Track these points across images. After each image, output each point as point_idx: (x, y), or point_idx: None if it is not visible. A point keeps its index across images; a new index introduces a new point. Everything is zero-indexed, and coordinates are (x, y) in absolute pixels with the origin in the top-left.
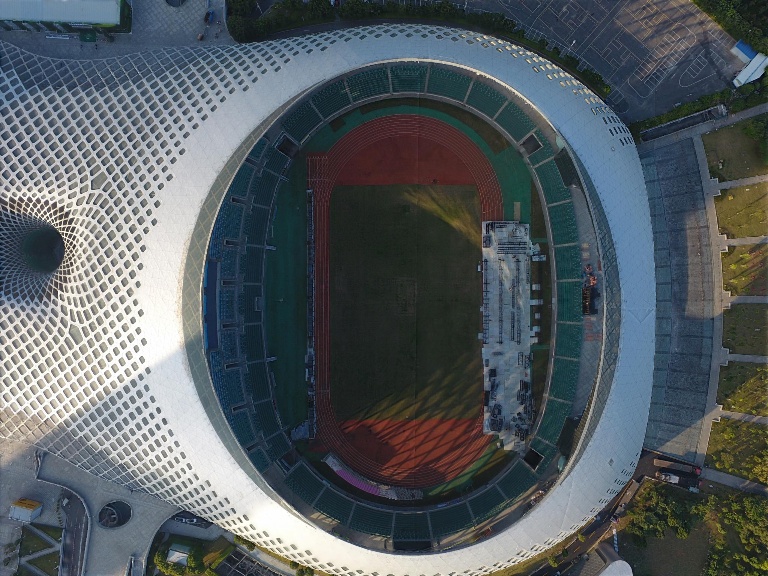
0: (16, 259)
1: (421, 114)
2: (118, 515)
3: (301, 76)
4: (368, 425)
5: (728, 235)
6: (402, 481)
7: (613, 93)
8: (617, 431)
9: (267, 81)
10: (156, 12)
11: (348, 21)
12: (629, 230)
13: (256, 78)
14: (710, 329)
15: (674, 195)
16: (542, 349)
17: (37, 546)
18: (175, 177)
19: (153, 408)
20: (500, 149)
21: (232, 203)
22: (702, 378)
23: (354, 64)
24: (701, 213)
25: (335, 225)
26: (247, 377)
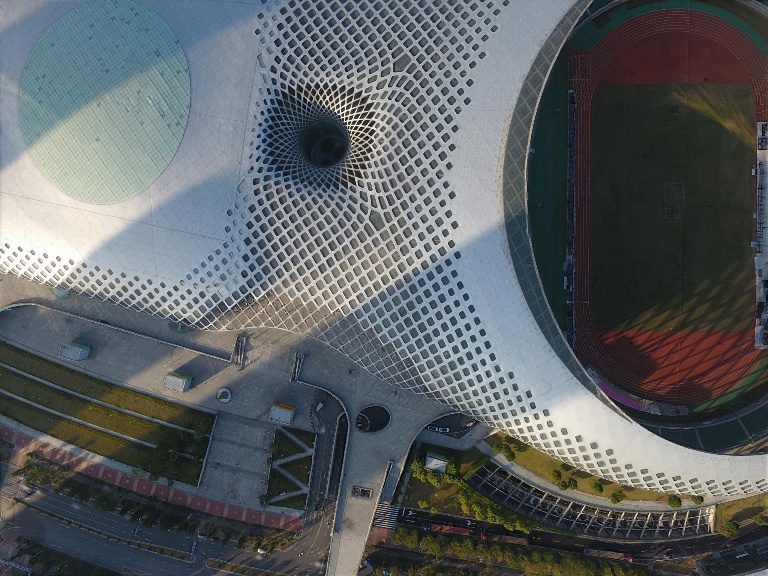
0: (298, 152)
1: (693, 8)
2: (370, 422)
3: None
4: (629, 337)
5: None
6: (665, 396)
7: None
8: None
9: None
10: None
11: None
12: None
13: None
14: None
15: None
16: None
17: (289, 450)
18: (489, 54)
19: (460, 295)
20: None
21: None
22: None
23: None
24: None
25: (597, 127)
26: None
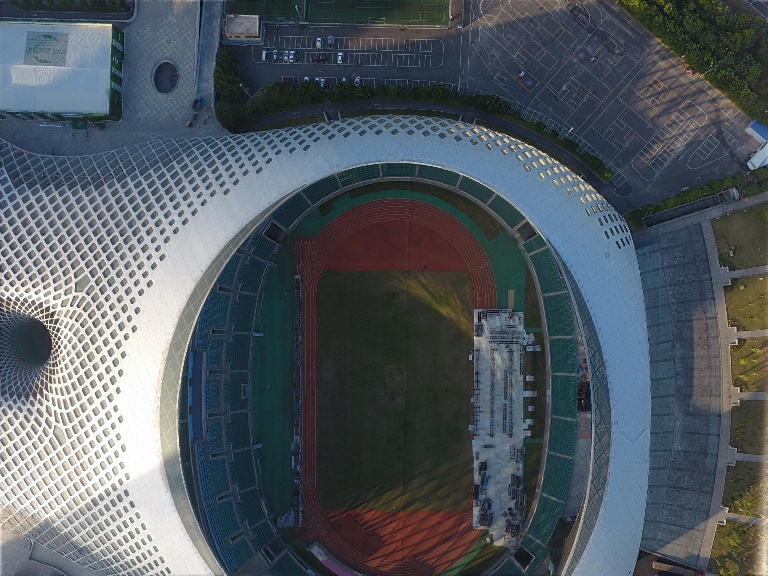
0: (7, 352)
1: (412, 198)
2: None
3: (282, 180)
4: (354, 515)
5: (738, 327)
6: (388, 573)
7: (615, 176)
8: (606, 555)
9: (248, 184)
10: (146, 99)
11: (338, 103)
12: (622, 345)
13: (237, 180)
14: (717, 426)
15: (680, 284)
16: (535, 443)
17: None
18: (155, 284)
19: (133, 513)
20: (494, 234)
21: (218, 292)
22: (707, 478)
23: (335, 168)
24: (709, 303)
25: (323, 311)
26: (233, 465)
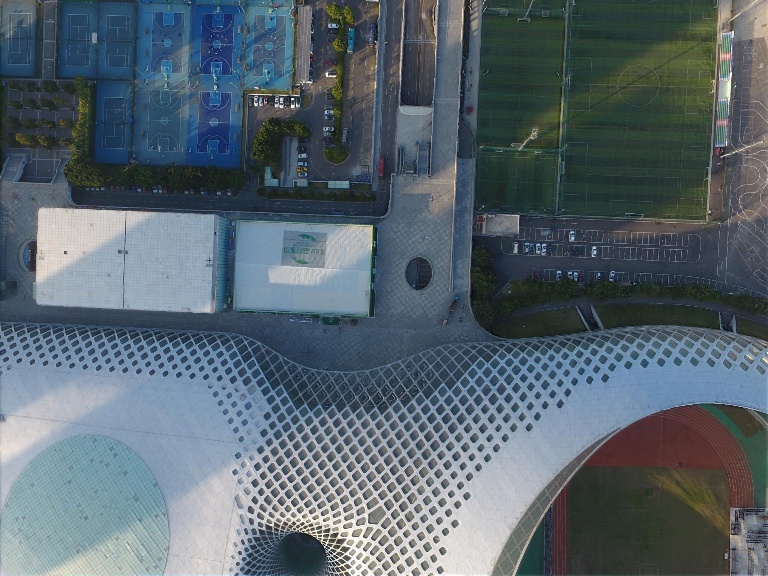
0: (277, 565)
1: None
2: None
3: (590, 419)
4: None
5: None
6: None
7: None
8: None
9: (552, 421)
10: (399, 295)
11: None
12: None
13: (538, 413)
14: None
15: None
16: None
17: None
18: (461, 525)
19: None
20: (752, 432)
21: None
22: None
23: (648, 410)
24: None
25: (573, 506)
26: None
